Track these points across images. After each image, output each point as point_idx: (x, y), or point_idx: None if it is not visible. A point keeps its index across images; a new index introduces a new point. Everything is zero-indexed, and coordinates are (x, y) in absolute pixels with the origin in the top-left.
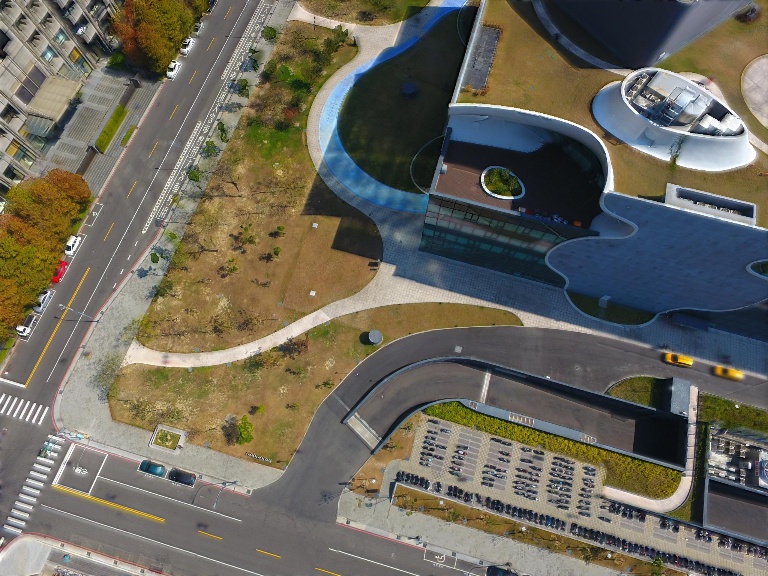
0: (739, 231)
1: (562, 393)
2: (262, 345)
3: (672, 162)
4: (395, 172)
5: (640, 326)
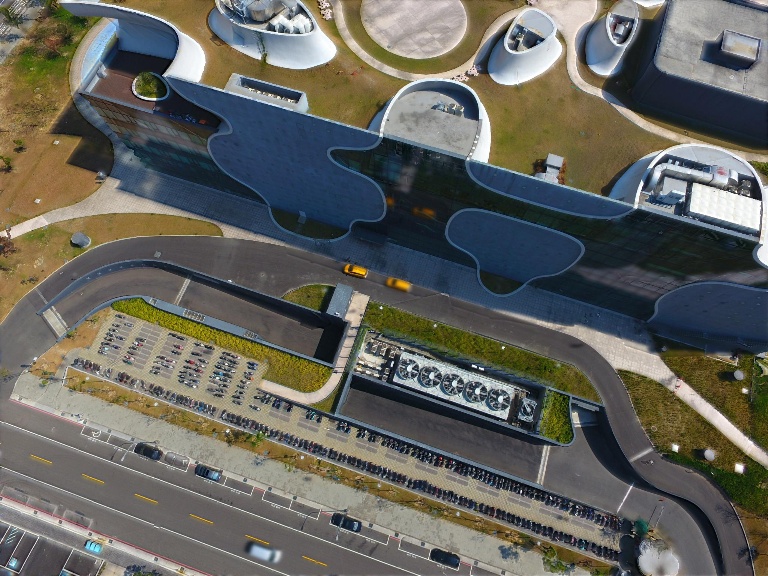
0: (281, 114)
1: (255, 300)
2: None
3: (263, 61)
4: None
5: (331, 241)
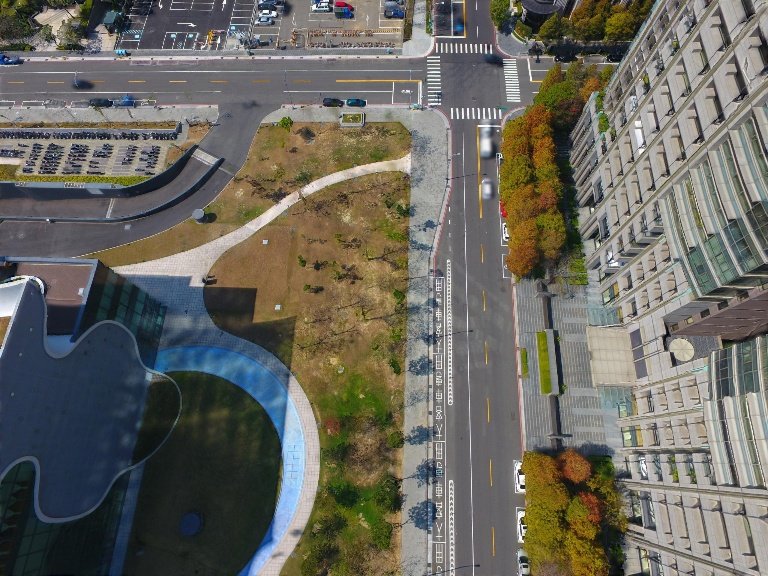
0: None
1: None
2: None
3: None
4: (200, 393)
5: None
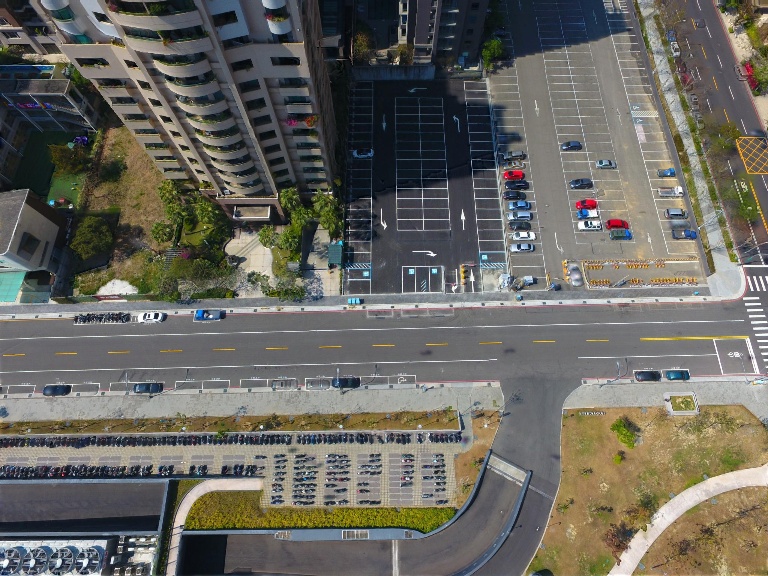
0: None
1: None
2: (652, 530)
3: None
4: None
5: None
